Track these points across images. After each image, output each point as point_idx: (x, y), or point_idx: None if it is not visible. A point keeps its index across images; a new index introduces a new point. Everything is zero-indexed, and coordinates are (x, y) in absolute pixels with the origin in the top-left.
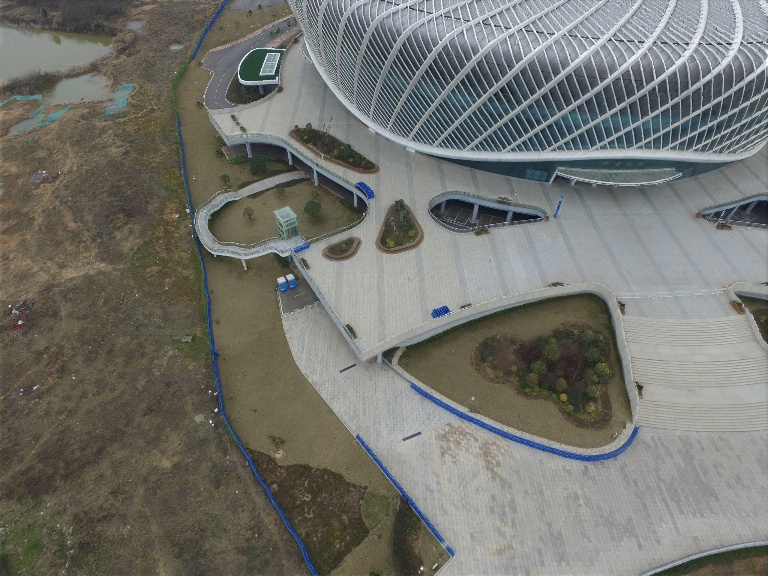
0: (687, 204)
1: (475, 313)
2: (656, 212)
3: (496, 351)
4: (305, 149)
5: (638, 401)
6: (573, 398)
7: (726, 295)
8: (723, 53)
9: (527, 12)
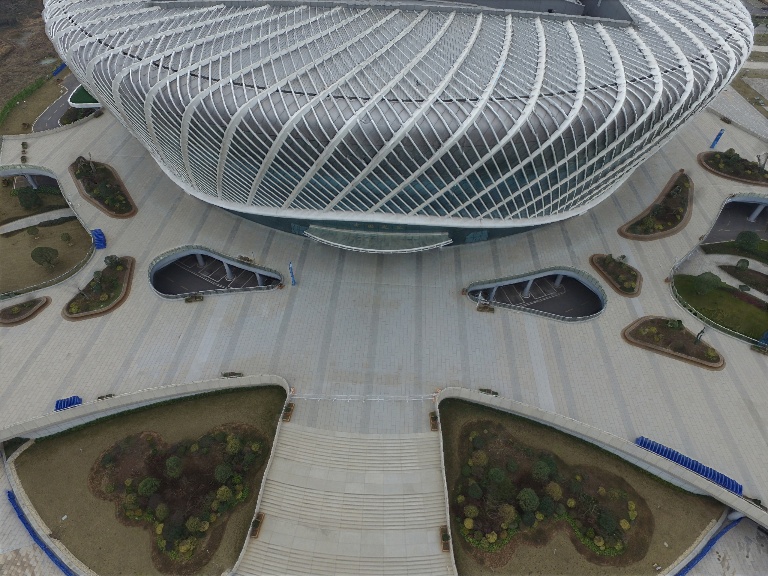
0: (462, 275)
1: (118, 405)
2: (417, 284)
3: (125, 455)
4: (73, 185)
5: (245, 543)
6: (164, 533)
7: (432, 403)
8: (407, 112)
9: (210, 52)
